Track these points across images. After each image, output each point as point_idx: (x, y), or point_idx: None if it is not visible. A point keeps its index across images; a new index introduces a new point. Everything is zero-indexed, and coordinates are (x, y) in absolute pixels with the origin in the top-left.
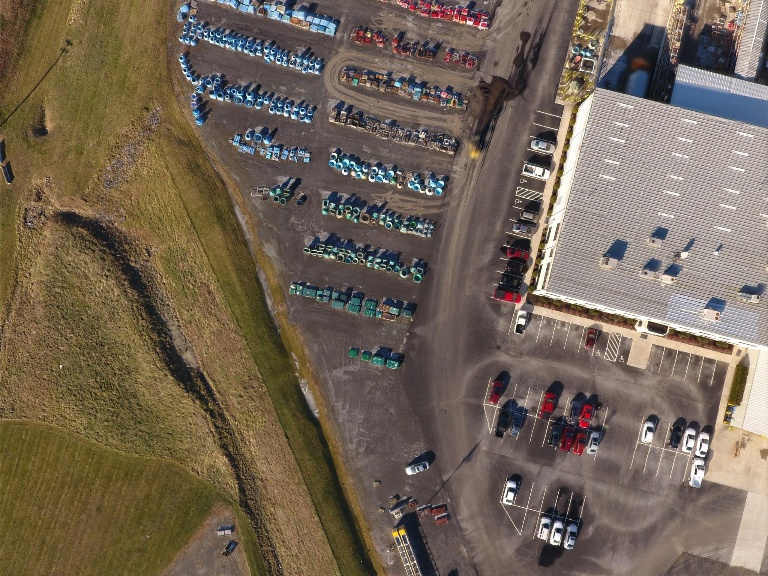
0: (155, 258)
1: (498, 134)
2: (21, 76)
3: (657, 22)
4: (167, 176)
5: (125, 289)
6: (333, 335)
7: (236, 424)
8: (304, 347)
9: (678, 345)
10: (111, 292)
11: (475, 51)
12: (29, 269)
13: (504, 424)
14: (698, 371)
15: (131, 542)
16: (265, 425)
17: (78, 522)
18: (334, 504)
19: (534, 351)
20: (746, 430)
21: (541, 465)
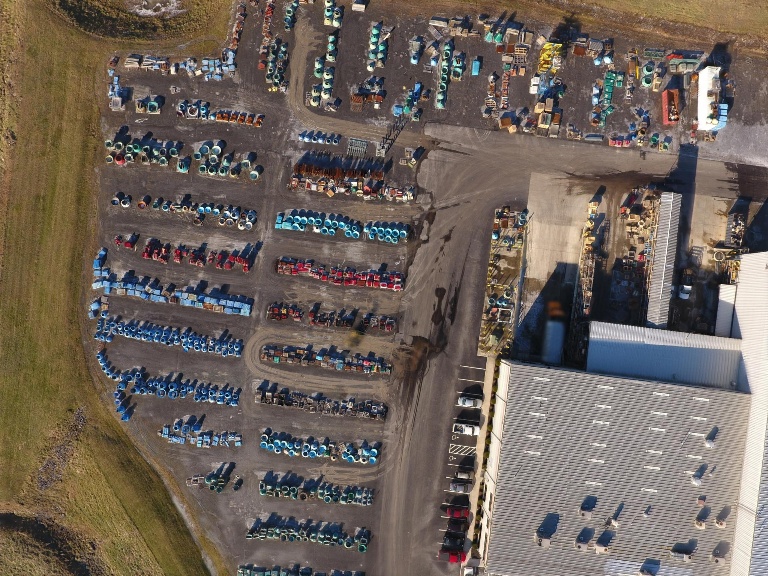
0: (100, 551)
1: (425, 394)
2: None
3: (569, 260)
4: (100, 476)
5: None
6: None
7: None
8: None
9: None
10: None
11: (392, 313)
12: None
13: None
14: None
15: None
16: None
17: None
18: None
19: None
20: None
21: None
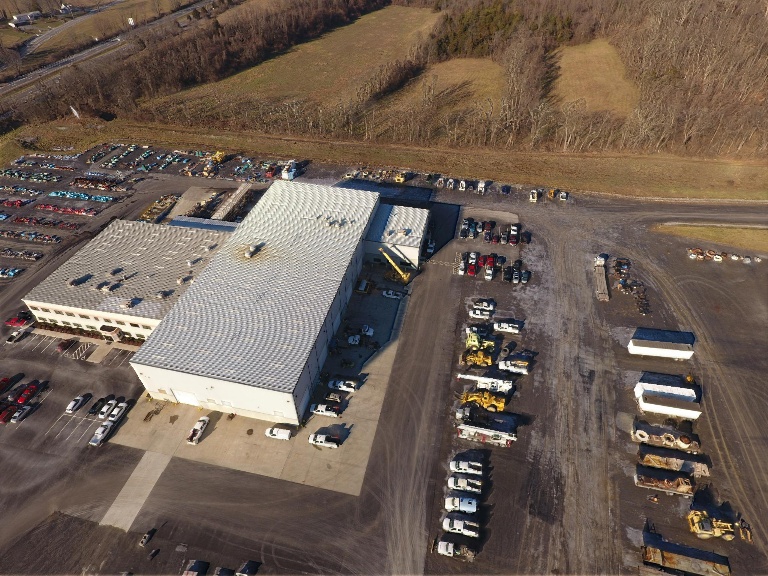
0: None
1: (71, 252)
2: None
3: None
4: None
5: None
6: None
7: None
8: None
9: (133, 347)
10: None
11: (81, 223)
12: None
13: None
14: None
15: None
16: None
17: None
18: None
19: (16, 355)
20: None
21: None
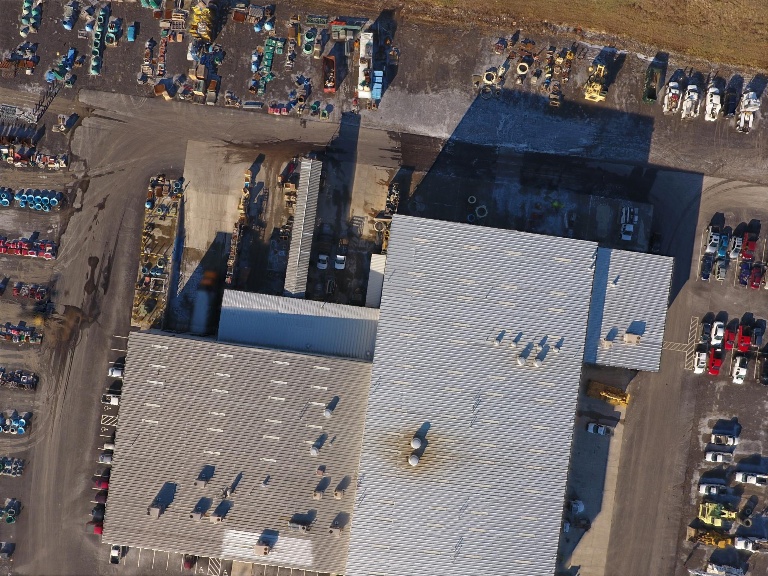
0: None
1: (77, 364)
2: None
3: (229, 229)
4: None
5: None
6: None
7: None
8: None
9: None
10: None
11: (44, 282)
12: None
13: None
14: (302, 575)
15: None
16: None
17: None
18: None
19: None
20: None
21: None
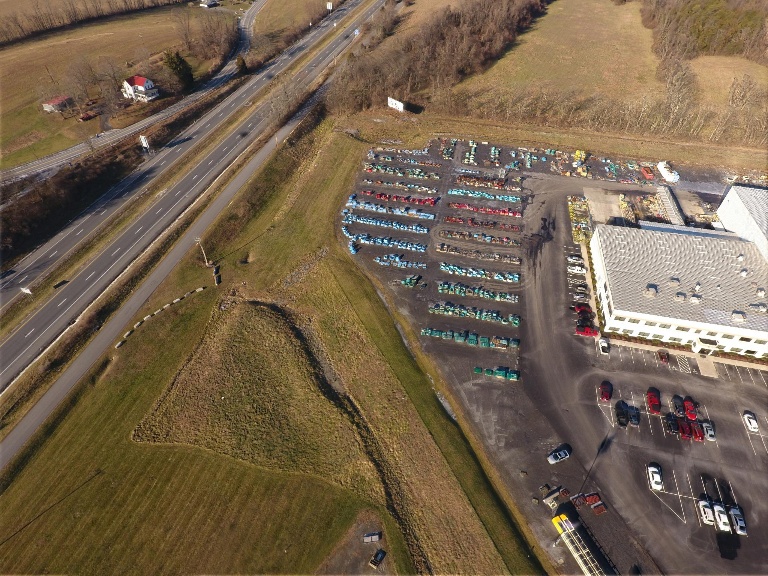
0: (315, 323)
1: (545, 256)
2: (239, 240)
3: (616, 216)
4: (331, 276)
5: (291, 339)
6: (459, 360)
7: (380, 434)
8: (437, 369)
9: (733, 361)
10: (279, 342)
11: (517, 225)
12: (214, 333)
13: (623, 414)
14: (761, 379)
15: (264, 560)
16: (409, 428)
17: (207, 542)
18: (486, 494)
19: (623, 367)
20: None
21: (672, 454)
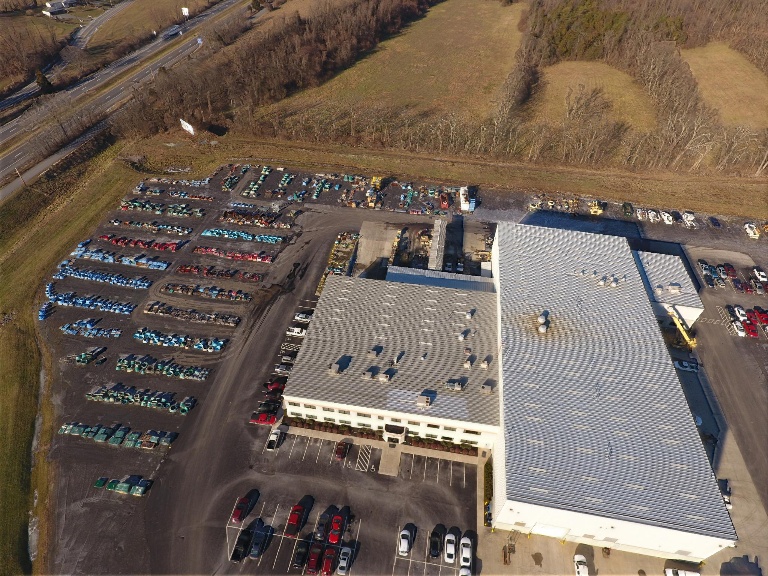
0: None
1: (272, 313)
2: None
3: (385, 256)
4: None
5: None
6: (86, 468)
7: None
8: (51, 482)
9: (425, 451)
10: None
11: (261, 273)
12: None
13: (242, 542)
14: (449, 474)
15: None
16: None
17: None
18: None
19: (286, 467)
20: (503, 526)
21: None
